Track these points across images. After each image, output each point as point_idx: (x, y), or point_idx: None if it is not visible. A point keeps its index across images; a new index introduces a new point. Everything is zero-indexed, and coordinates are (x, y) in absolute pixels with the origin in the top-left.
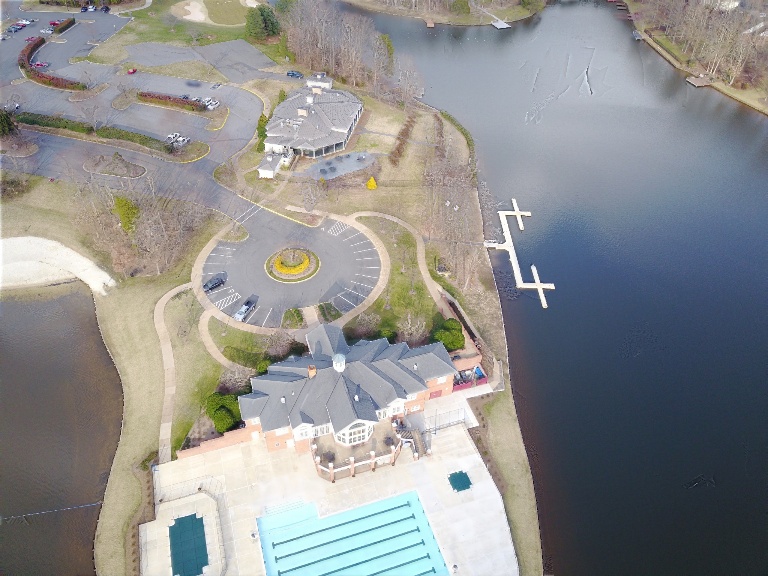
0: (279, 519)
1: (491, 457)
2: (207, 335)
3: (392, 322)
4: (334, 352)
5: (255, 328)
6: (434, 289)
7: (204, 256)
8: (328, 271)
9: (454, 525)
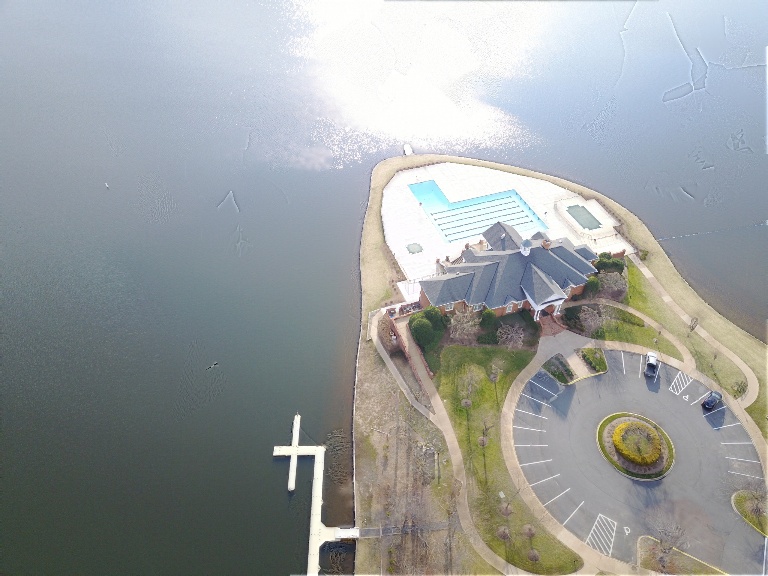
0: (534, 231)
1: (390, 262)
2: (672, 340)
3: (485, 357)
4: (534, 269)
5: (628, 348)
6: (440, 413)
7: (764, 456)
8: (583, 435)
9: (420, 228)
